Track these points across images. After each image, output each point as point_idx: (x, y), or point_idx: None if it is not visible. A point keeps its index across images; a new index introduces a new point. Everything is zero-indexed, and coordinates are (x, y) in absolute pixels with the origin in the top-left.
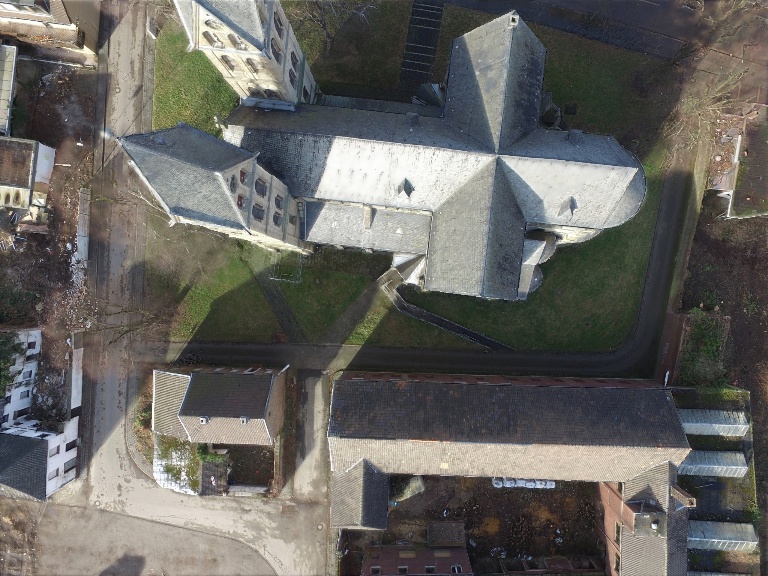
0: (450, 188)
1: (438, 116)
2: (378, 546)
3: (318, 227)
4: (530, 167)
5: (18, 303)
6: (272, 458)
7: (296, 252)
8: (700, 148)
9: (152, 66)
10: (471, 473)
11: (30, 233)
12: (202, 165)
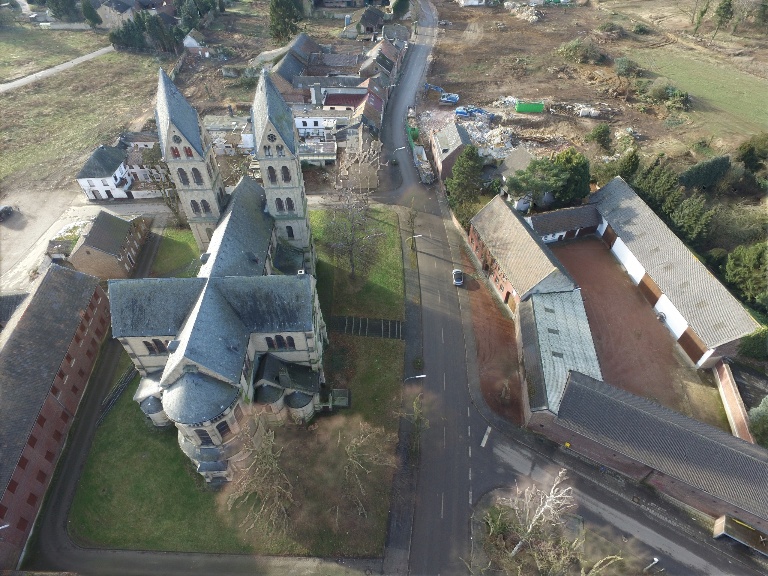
0: None
1: None
2: None
3: None
4: None
5: None
6: None
7: None
8: None
9: None
10: None
11: None
12: (171, 112)
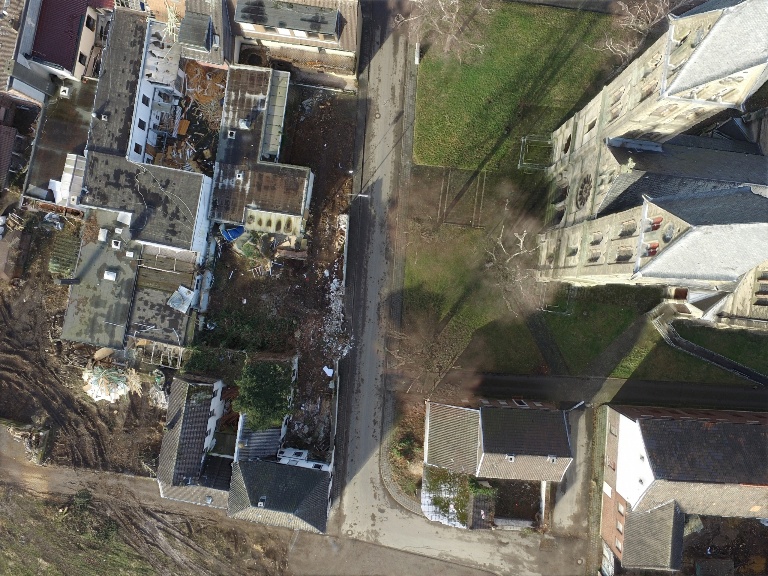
0: None
1: (755, 153)
2: None
3: None
4: None
5: (274, 329)
6: (533, 491)
7: (562, 283)
8: None
9: (414, 92)
10: None
11: (288, 259)
12: None
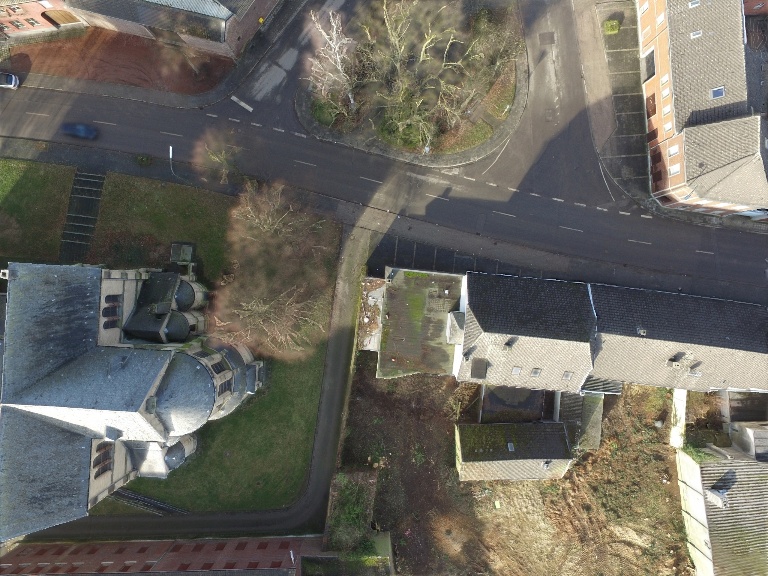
0: None
1: None
2: None
3: None
4: (42, 410)
5: None
6: None
7: None
8: None
9: None
10: None
11: None
12: None
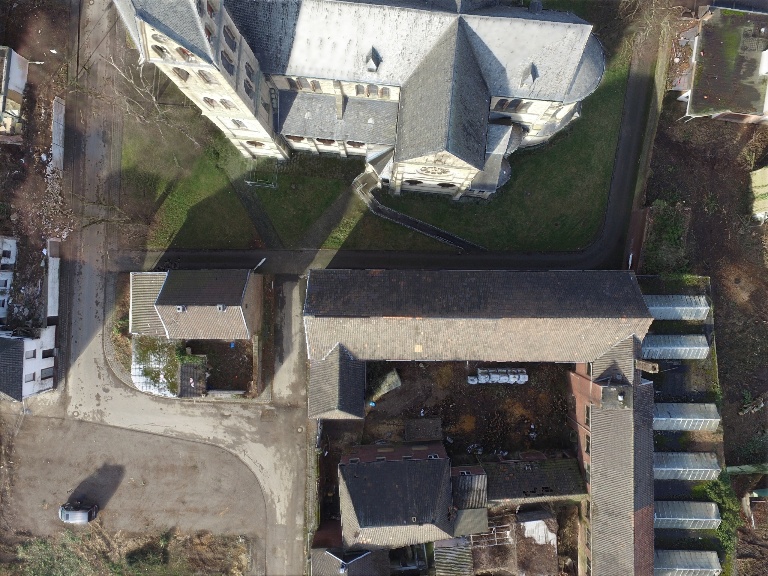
0: (416, 57)
1: None
2: (357, 446)
3: (291, 119)
4: (491, 28)
5: None
6: (251, 362)
7: (272, 158)
8: (660, 53)
9: None
10: (445, 357)
11: (4, 144)
12: None
